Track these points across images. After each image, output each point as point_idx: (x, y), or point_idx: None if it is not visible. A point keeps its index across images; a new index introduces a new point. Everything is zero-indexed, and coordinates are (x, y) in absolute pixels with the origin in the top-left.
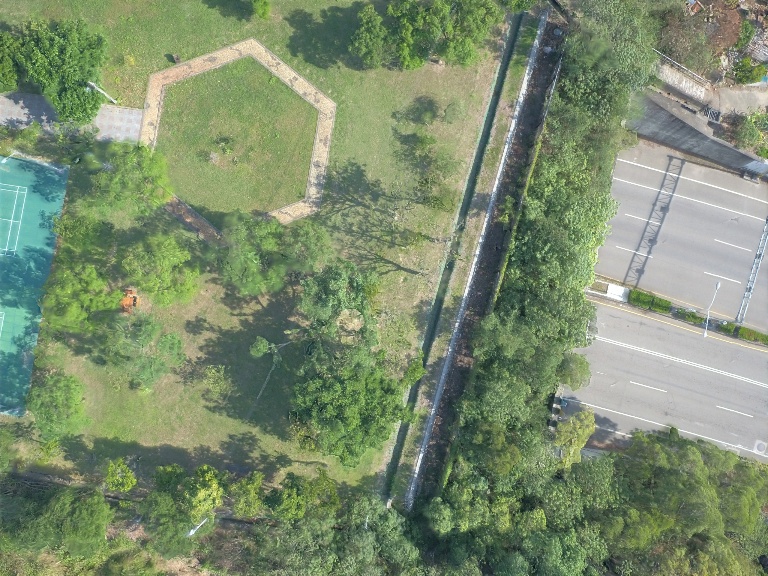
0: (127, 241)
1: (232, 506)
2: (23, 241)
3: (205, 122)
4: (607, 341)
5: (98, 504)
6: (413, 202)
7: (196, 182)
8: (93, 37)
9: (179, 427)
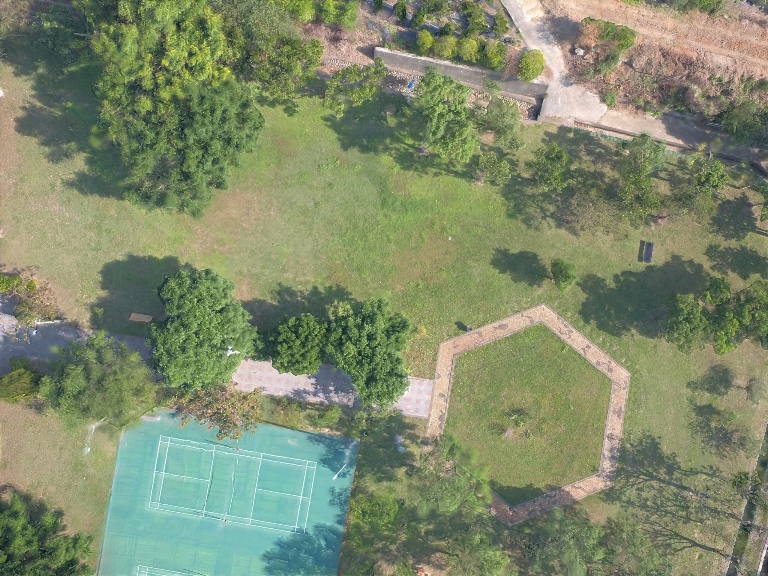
0: (418, 517)
1: None
2: (313, 518)
3: (497, 393)
4: None
5: None
6: (734, 501)
7: (488, 456)
8: (397, 319)
9: None
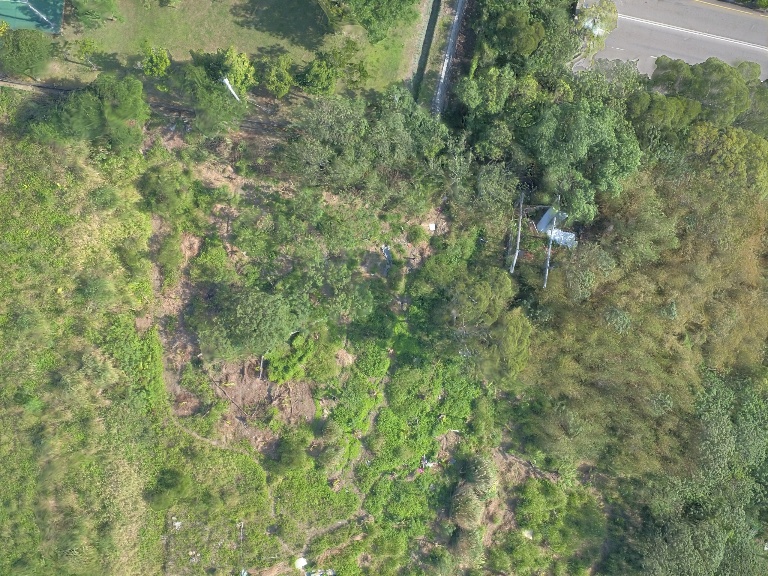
0: None
1: (263, 115)
2: None
3: None
4: (626, 17)
5: (134, 80)
6: None
7: None
8: None
9: (209, 42)
